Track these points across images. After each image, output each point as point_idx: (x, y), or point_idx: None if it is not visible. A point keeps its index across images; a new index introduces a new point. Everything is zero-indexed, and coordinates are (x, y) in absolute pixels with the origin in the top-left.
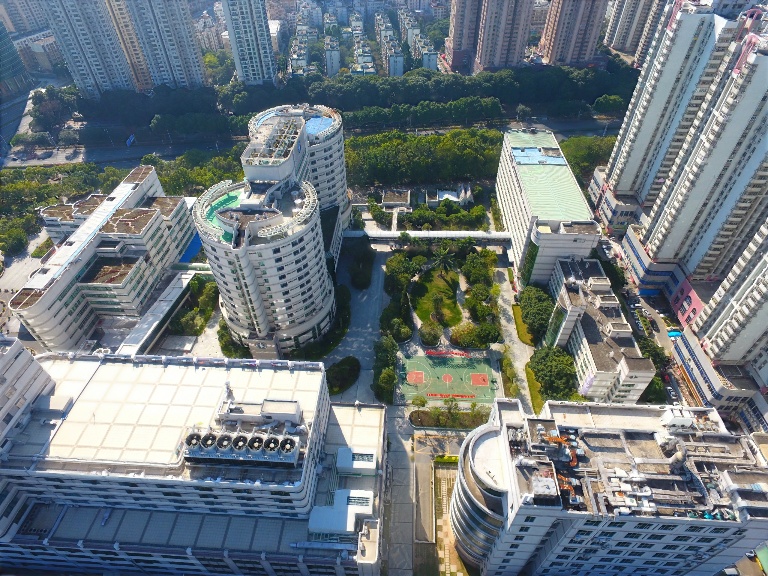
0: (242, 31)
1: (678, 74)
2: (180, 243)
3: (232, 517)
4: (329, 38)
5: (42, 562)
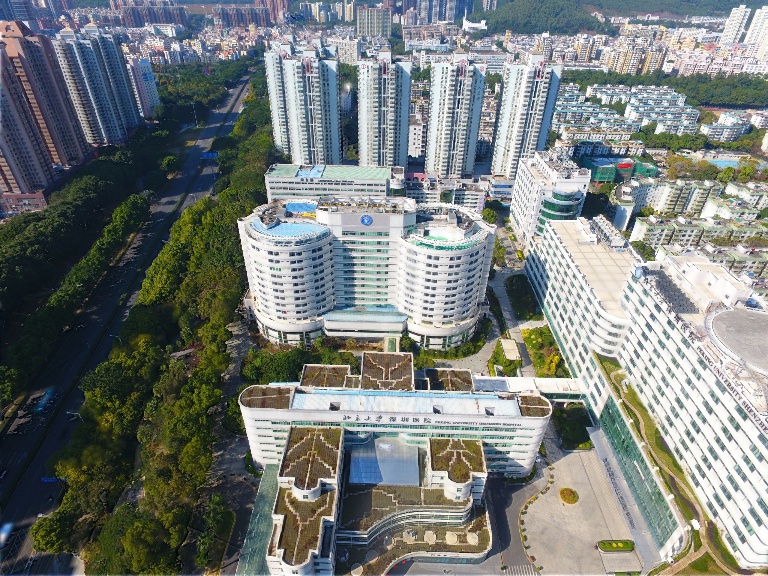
0: None
1: None
2: None
3: None
4: None
5: None
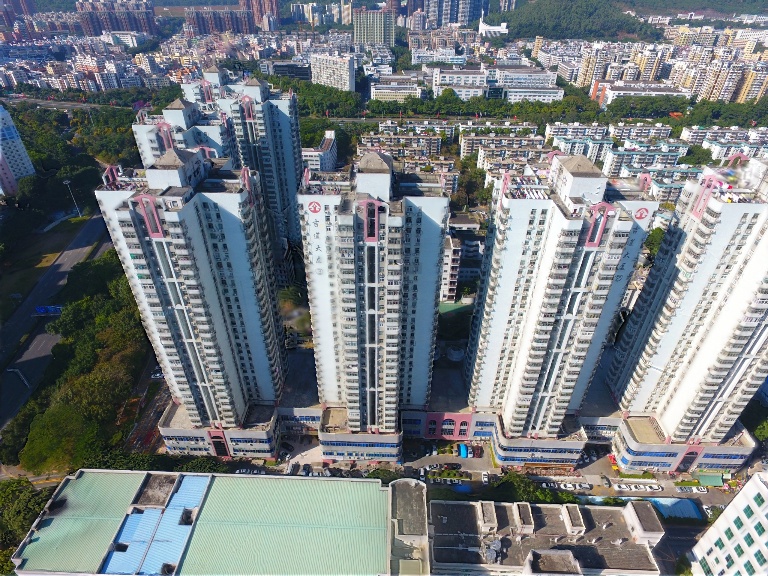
0: None
1: (212, 273)
2: None
3: None
4: None
5: None
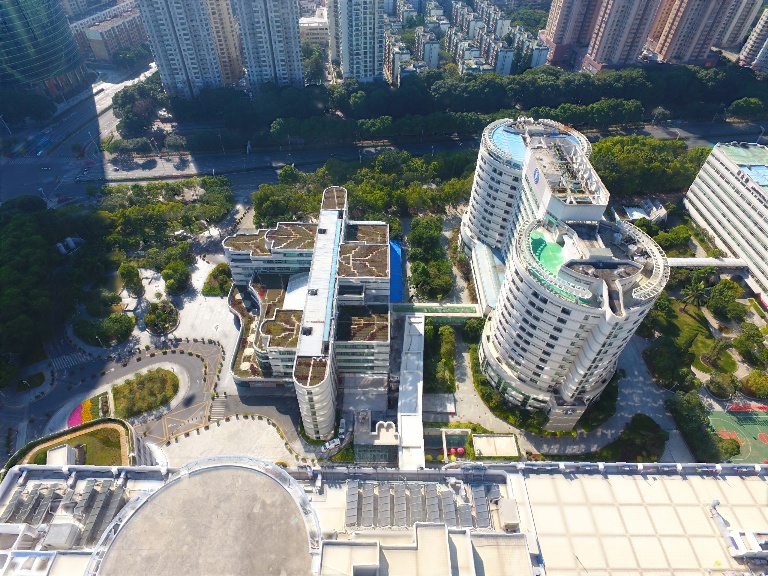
0: (361, 23)
1: None
2: None
3: None
4: (422, 29)
5: None
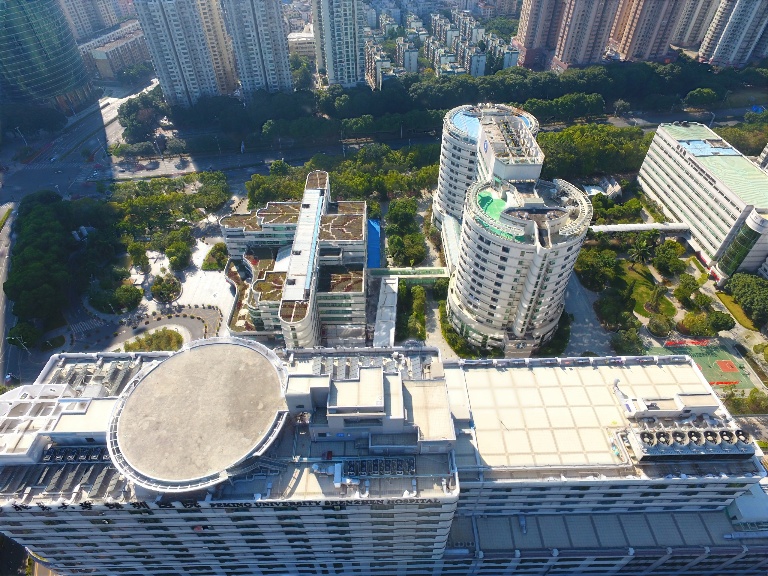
0: (343, 33)
1: None
2: (366, 248)
3: (646, 514)
4: (402, 39)
5: None
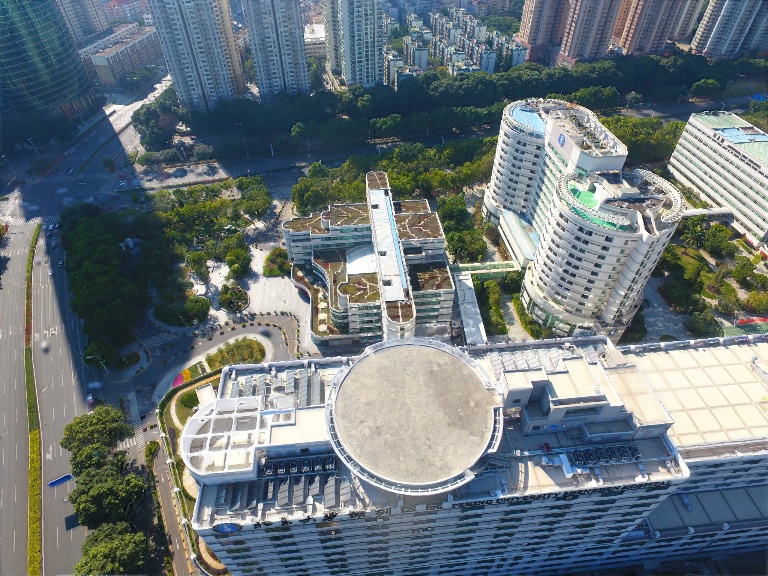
0: (363, 33)
1: None
2: None
3: None
4: (409, 38)
5: (596, 562)
